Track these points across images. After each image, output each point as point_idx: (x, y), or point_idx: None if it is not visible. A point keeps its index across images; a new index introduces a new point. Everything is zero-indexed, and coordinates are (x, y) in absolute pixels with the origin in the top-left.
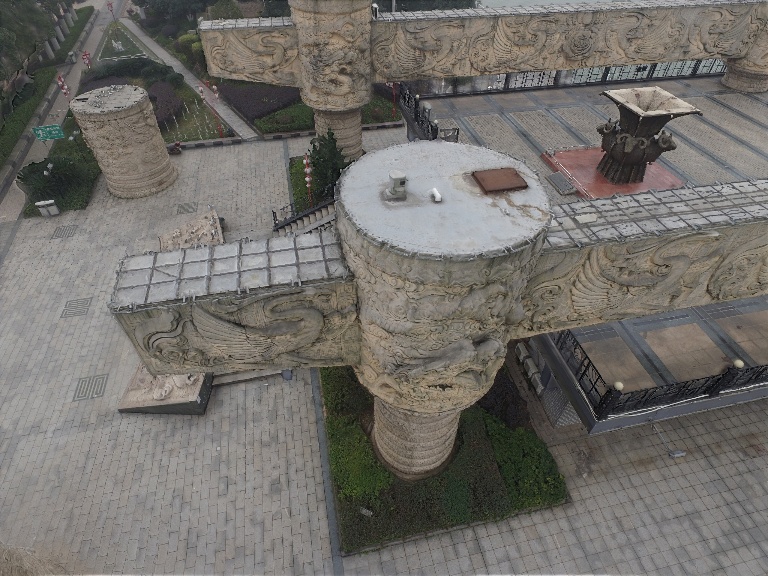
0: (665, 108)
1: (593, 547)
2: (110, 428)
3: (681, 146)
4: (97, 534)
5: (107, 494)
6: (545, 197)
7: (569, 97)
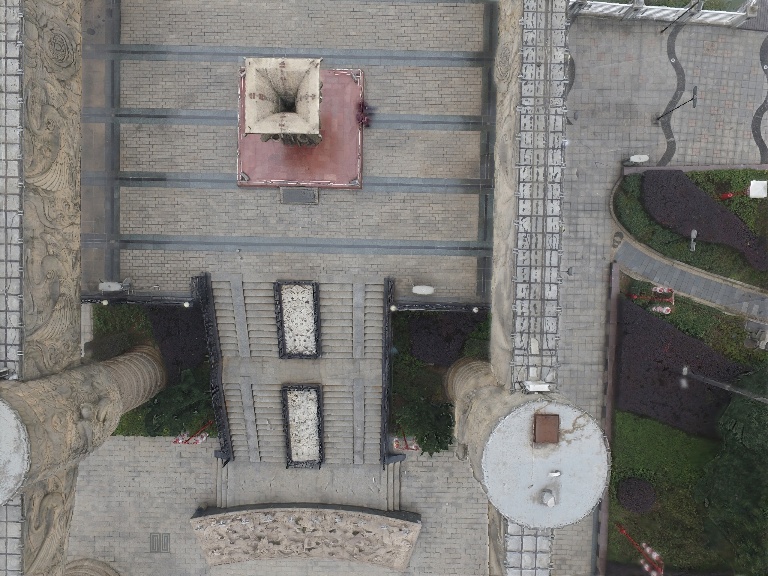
0: (292, 82)
1: None
2: (415, 573)
3: (251, 8)
4: (483, 568)
5: (460, 567)
6: (569, 408)
7: (87, 62)
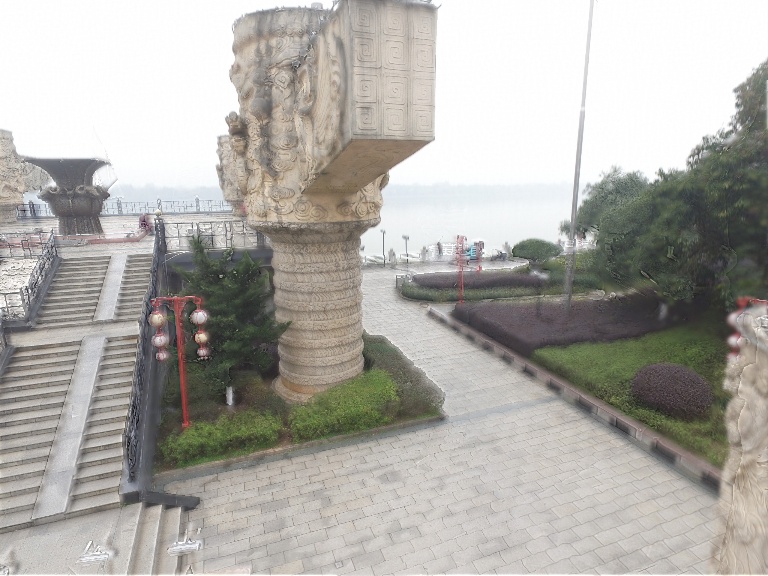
0: None
1: (394, 332)
2: None
3: None
4: None
5: None
6: None
7: None
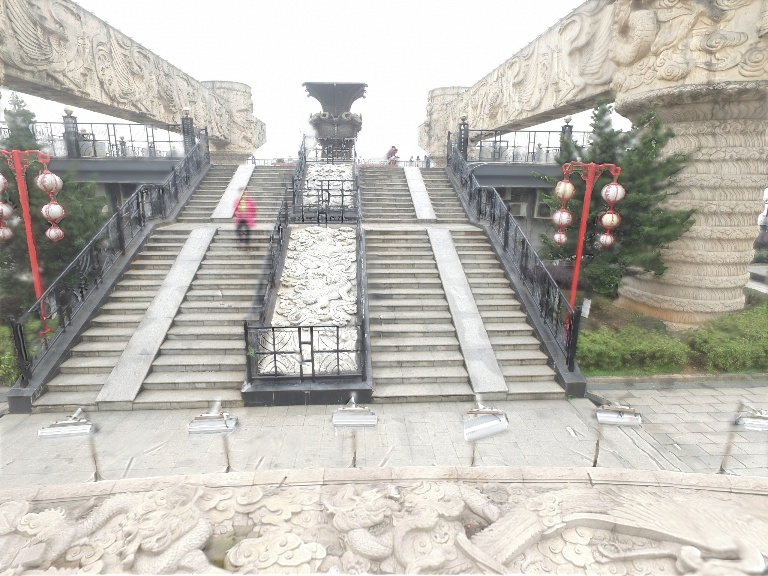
0: None
1: None
2: None
3: None
4: None
5: None
6: None
7: None
